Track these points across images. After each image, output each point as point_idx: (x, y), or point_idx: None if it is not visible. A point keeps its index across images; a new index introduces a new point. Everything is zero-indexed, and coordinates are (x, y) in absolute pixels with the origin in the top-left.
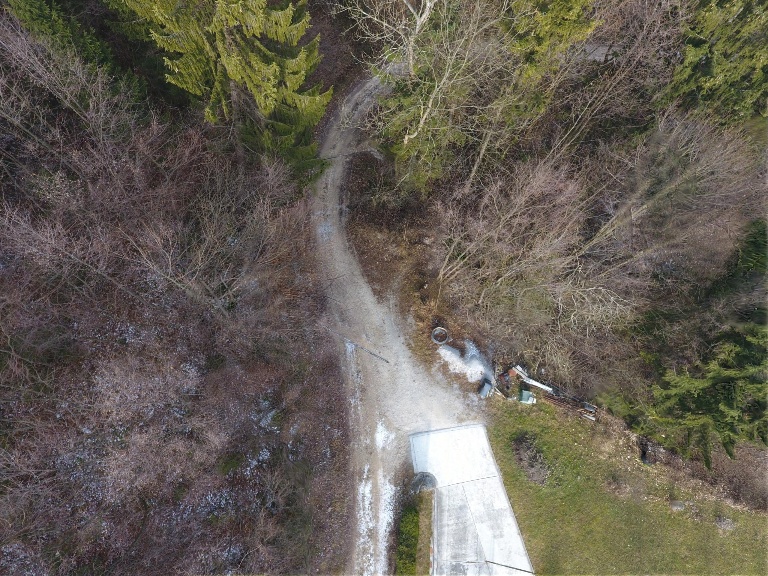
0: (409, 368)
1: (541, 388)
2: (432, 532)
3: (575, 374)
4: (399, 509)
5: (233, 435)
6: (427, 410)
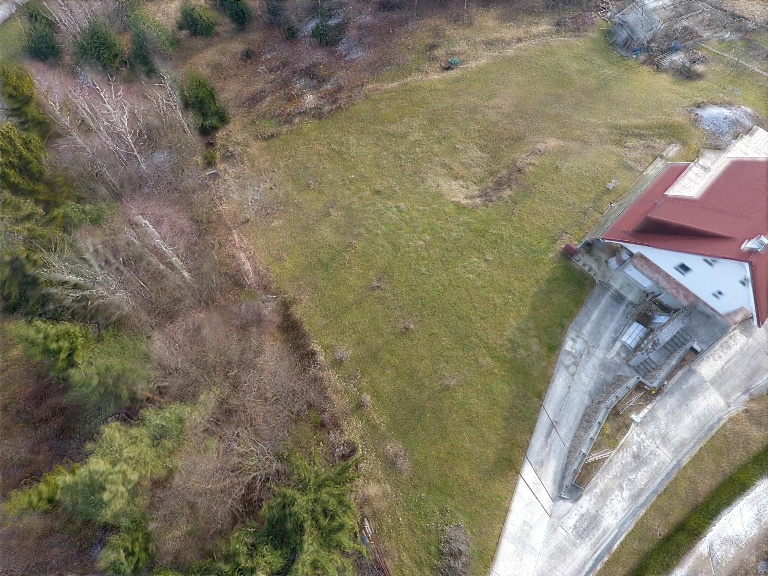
0: None
1: None
2: None
3: None
4: None
5: None
6: None
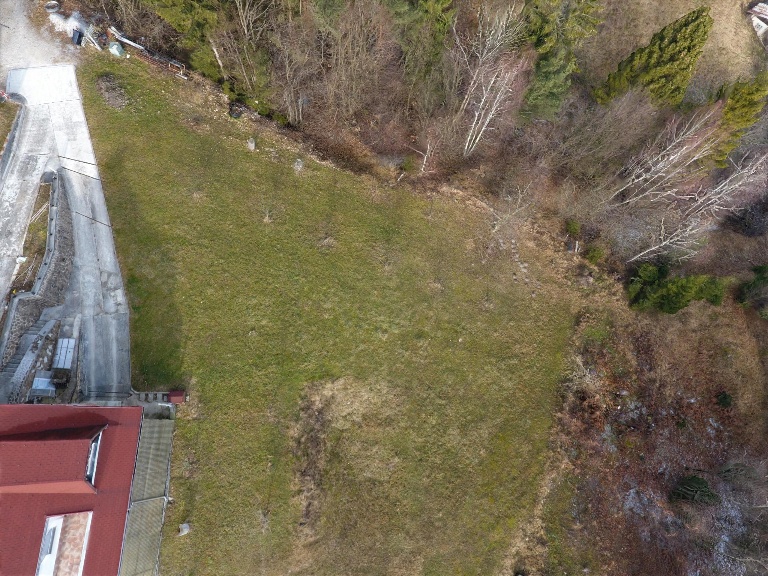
0: (24, 30)
1: (135, 47)
2: (10, 130)
3: (138, 16)
4: None
5: None
6: (29, 55)
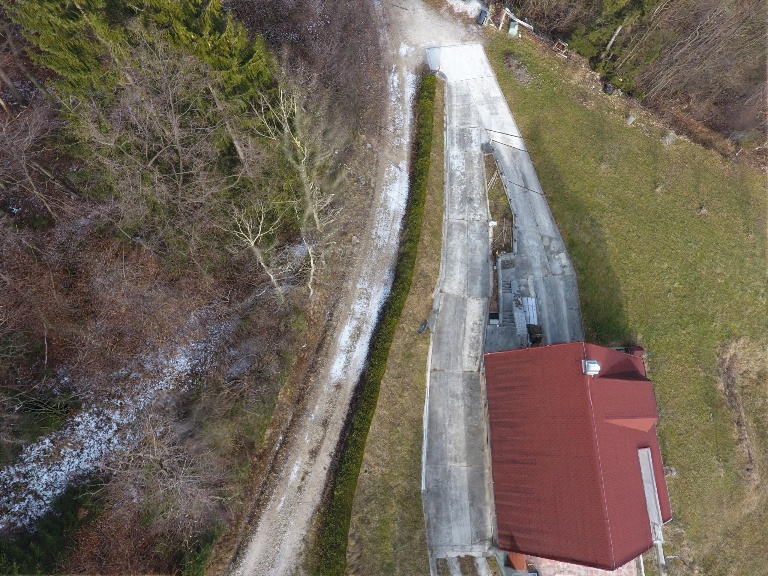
0: (423, 11)
1: (525, 27)
2: (445, 104)
3: None
4: (420, 86)
5: (299, 2)
6: (438, 35)
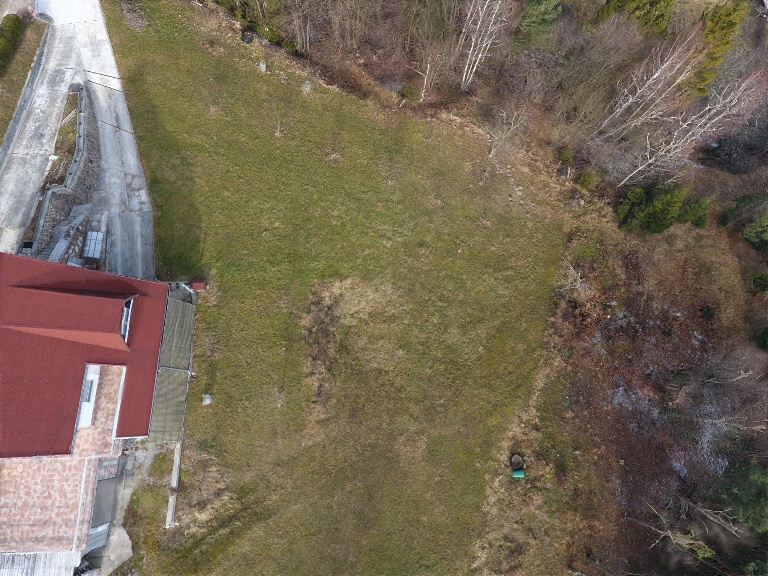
0: None
1: None
2: (40, 45)
3: None
4: None
5: None
6: None
